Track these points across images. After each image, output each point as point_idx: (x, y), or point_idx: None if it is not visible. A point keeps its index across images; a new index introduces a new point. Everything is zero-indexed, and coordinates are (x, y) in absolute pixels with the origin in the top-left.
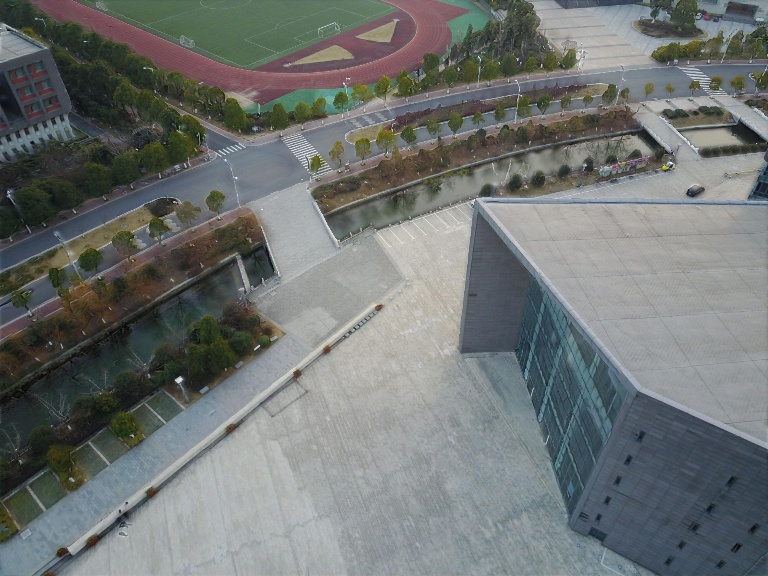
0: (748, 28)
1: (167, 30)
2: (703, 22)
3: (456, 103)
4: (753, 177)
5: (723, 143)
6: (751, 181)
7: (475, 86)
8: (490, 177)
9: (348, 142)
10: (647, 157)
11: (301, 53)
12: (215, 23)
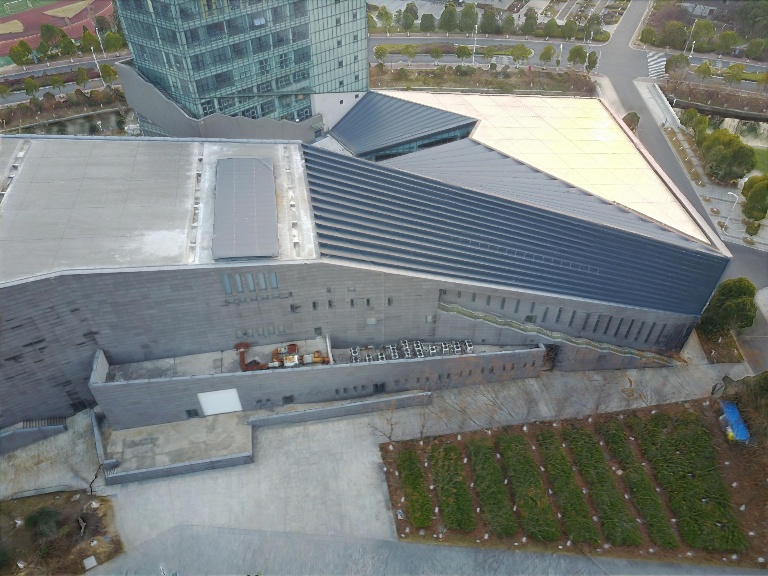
0: (426, 6)
1: None
2: (390, 0)
3: None
4: None
5: None
6: None
7: (103, 56)
8: None
9: None
10: None
11: None
12: None
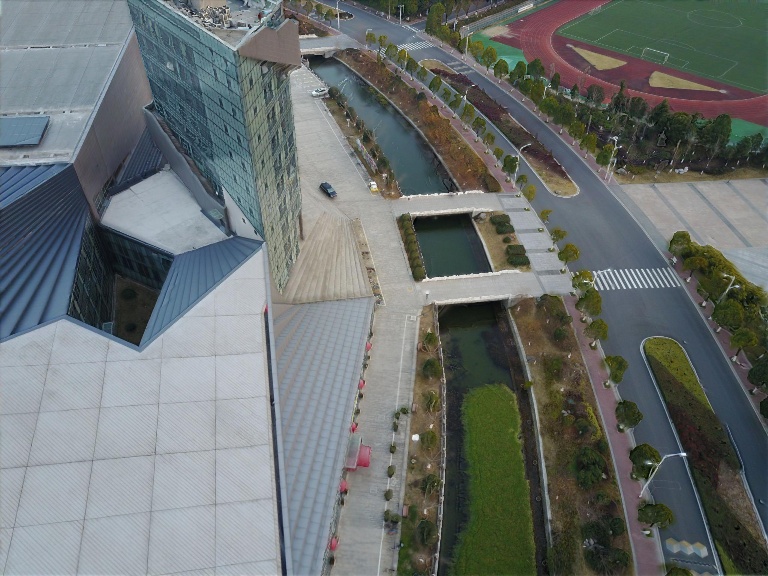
0: None
1: (621, 5)
2: None
3: (500, 103)
4: (345, 230)
5: (447, 255)
6: (335, 223)
7: None
8: (384, 117)
9: (422, 60)
10: (374, 163)
11: (599, 50)
12: (649, 18)
